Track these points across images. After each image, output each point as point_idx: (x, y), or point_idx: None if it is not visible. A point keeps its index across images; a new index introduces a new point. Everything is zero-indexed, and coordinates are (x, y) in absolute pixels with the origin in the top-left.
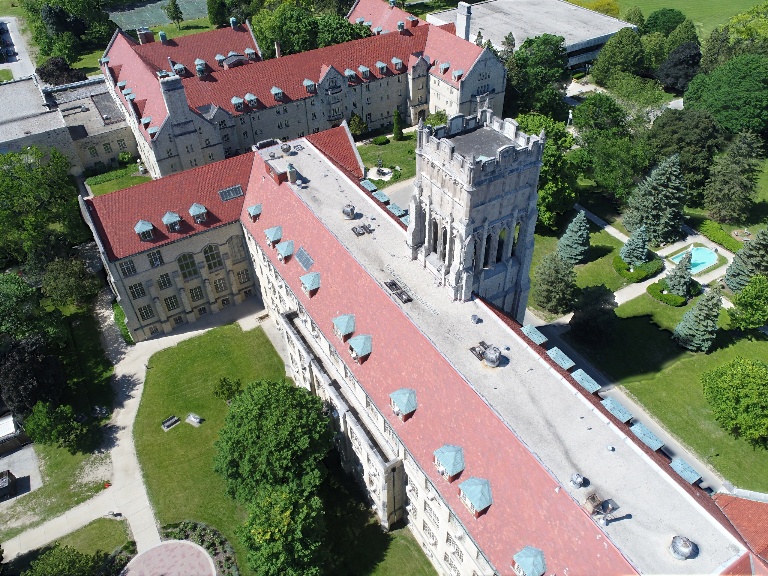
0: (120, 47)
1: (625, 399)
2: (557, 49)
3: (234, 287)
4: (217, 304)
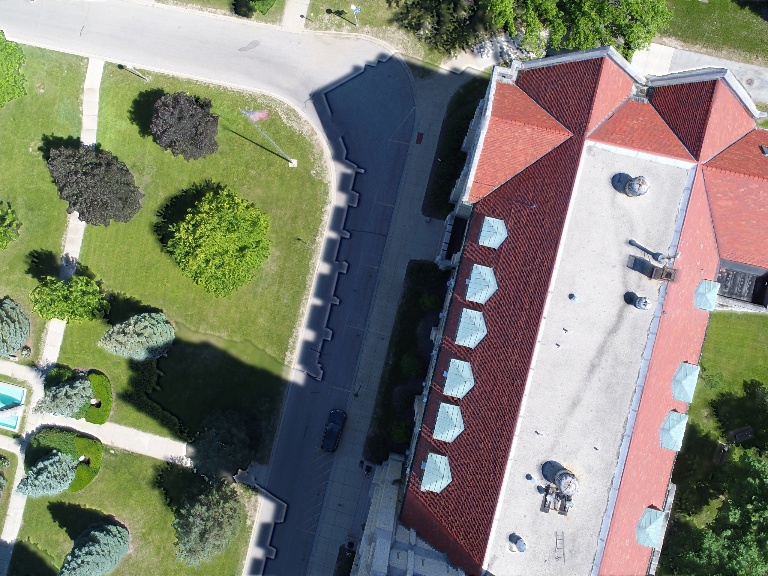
0: None
1: (301, 350)
2: None
3: None
4: None
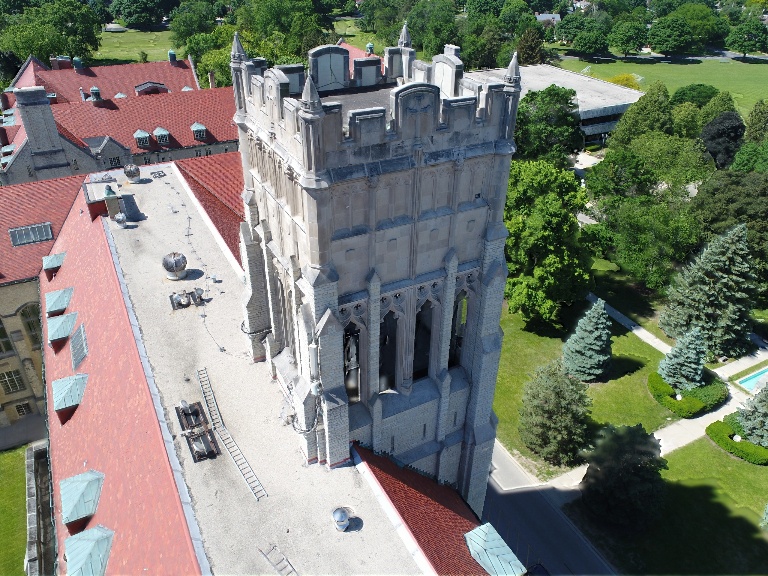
0: (26, 74)
1: None
2: (566, 102)
3: (36, 386)
4: (4, 412)
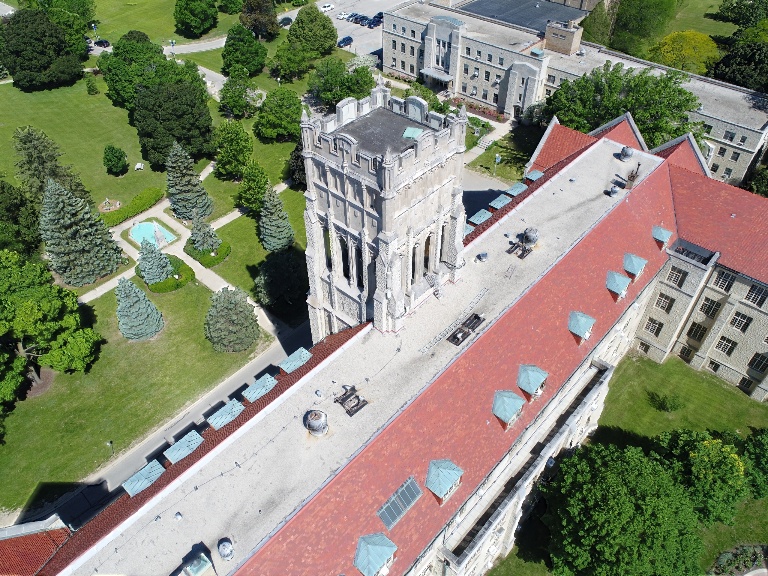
0: None
1: None
2: None
3: None
4: None
